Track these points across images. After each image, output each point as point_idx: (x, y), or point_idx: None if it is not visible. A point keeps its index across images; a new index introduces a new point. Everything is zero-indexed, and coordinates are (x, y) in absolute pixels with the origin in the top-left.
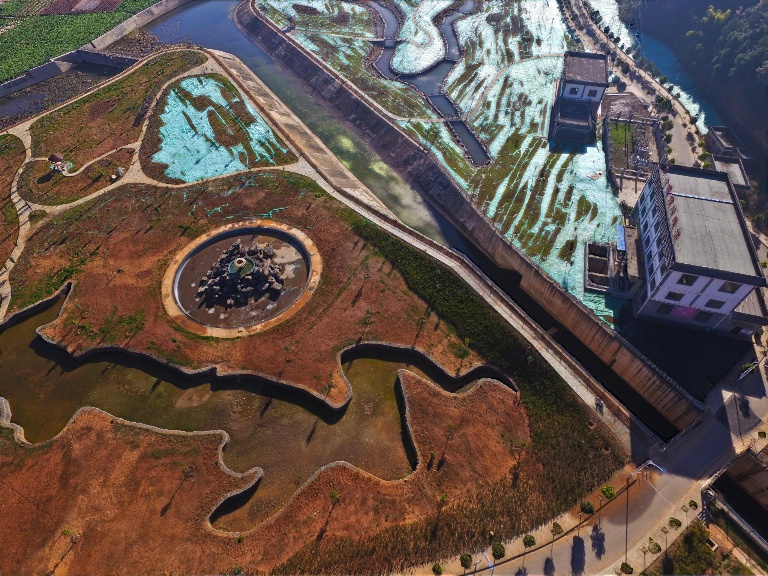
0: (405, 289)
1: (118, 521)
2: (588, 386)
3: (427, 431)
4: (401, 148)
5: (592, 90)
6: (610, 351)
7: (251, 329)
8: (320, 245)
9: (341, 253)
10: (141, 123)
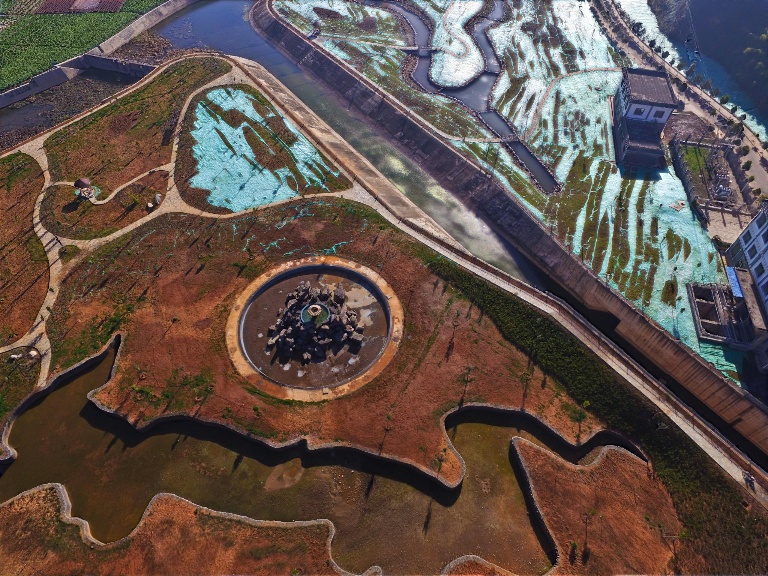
0: (500, 339)
1: None
2: (731, 457)
3: (560, 514)
4: (459, 171)
5: (659, 111)
6: (735, 410)
7: (337, 390)
8: (396, 286)
9: (421, 296)
10: (171, 141)
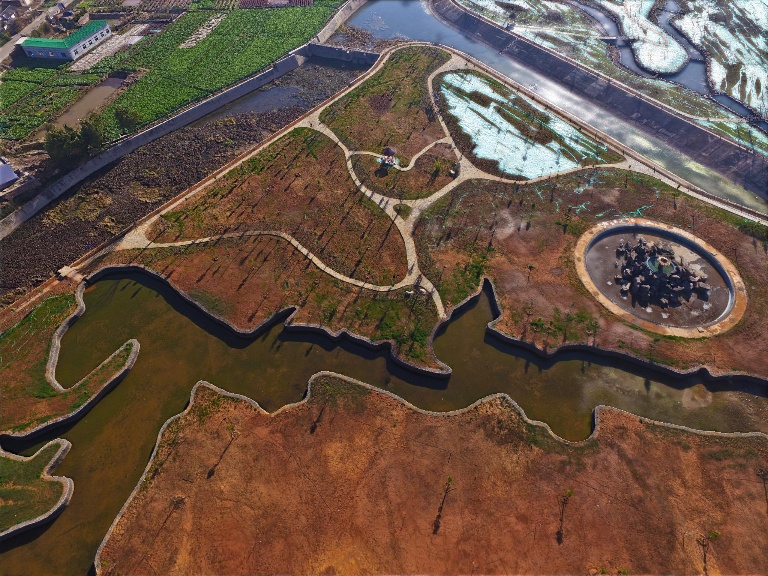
0: None
1: (731, 524)
2: None
3: None
4: (715, 148)
5: None
6: None
7: (711, 329)
8: (716, 245)
9: (746, 253)
10: (435, 118)
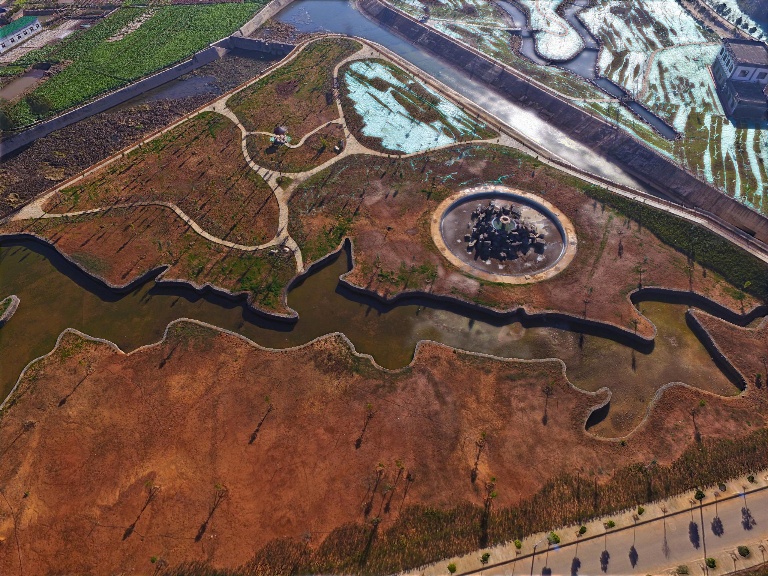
0: (660, 243)
1: (509, 429)
2: None
3: (741, 357)
4: (586, 125)
5: (762, 72)
6: None
7: (537, 277)
8: (561, 207)
9: (585, 213)
10: (334, 102)
